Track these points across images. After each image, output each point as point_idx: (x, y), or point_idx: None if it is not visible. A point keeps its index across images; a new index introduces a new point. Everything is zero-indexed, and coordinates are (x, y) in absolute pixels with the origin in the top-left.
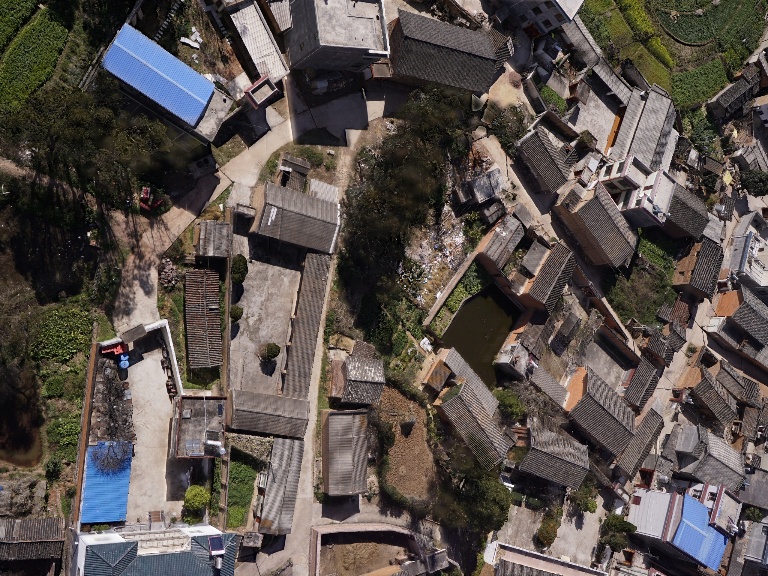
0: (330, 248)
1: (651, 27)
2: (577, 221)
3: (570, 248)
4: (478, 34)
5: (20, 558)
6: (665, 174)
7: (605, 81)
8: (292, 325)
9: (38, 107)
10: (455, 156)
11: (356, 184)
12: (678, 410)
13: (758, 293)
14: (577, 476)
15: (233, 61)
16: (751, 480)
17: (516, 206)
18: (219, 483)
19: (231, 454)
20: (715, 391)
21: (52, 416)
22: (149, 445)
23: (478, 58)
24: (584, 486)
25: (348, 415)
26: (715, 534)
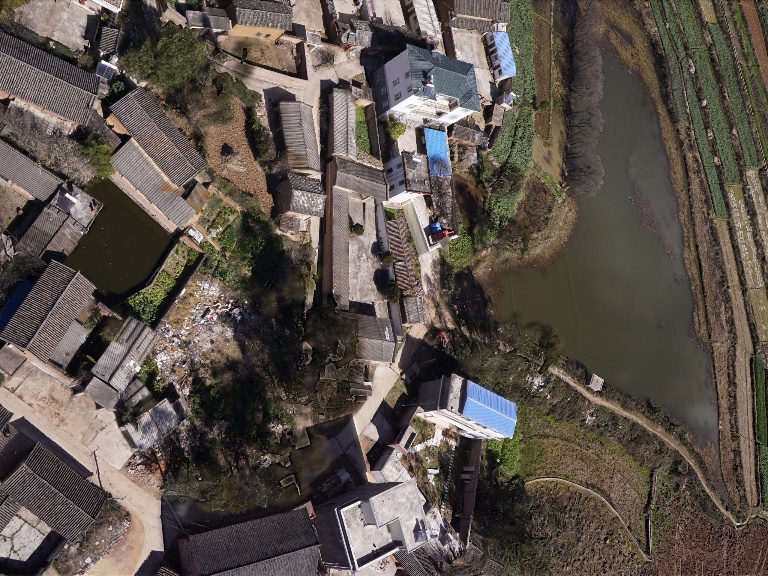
0: None
1: None
2: None
3: None
4: None
5: (465, 121)
6: None
7: None
8: None
9: None
10: None
11: None
12: None
13: None
14: (1, 43)
15: None
16: None
17: None
18: None
19: None
20: None
21: None
22: None
23: (225, 569)
24: None
25: (311, 168)
26: None
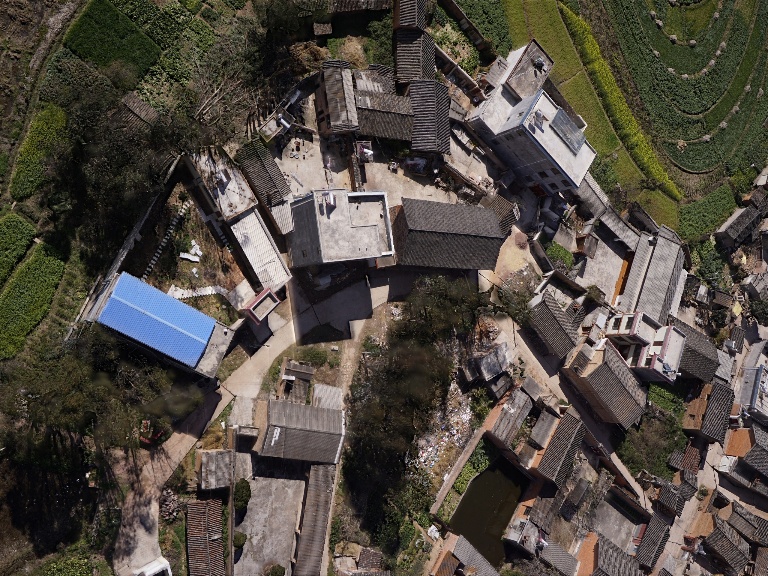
0: (335, 458)
1: (658, 161)
2: (586, 384)
3: (579, 407)
4: (484, 210)
5: None
6: (675, 329)
7: (612, 229)
8: (297, 539)
9: (34, 348)
10: (461, 330)
11: (361, 378)
12: (690, 561)
13: None
14: None
15: (234, 269)
16: None
17: (524, 380)
18: None
19: None
20: (728, 539)
21: None
22: None
23: (484, 238)
24: None
25: None
26: None
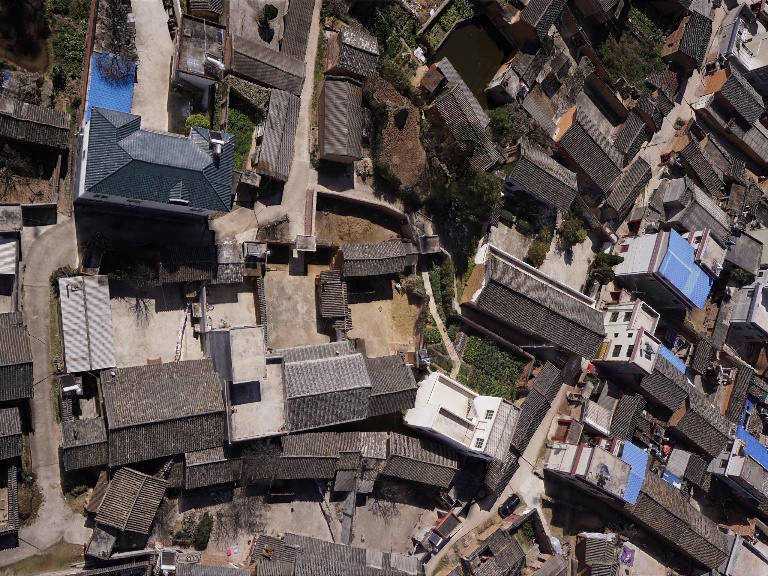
0: None
1: None
2: None
3: None
4: None
5: (28, 139)
6: None
7: None
8: None
9: None
10: None
11: None
12: (666, 171)
13: None
14: (566, 197)
15: None
16: (737, 242)
17: None
18: (218, 126)
19: (230, 101)
20: (702, 156)
21: (58, 30)
22: (151, 76)
23: None
24: (573, 220)
25: (343, 81)
26: (700, 273)
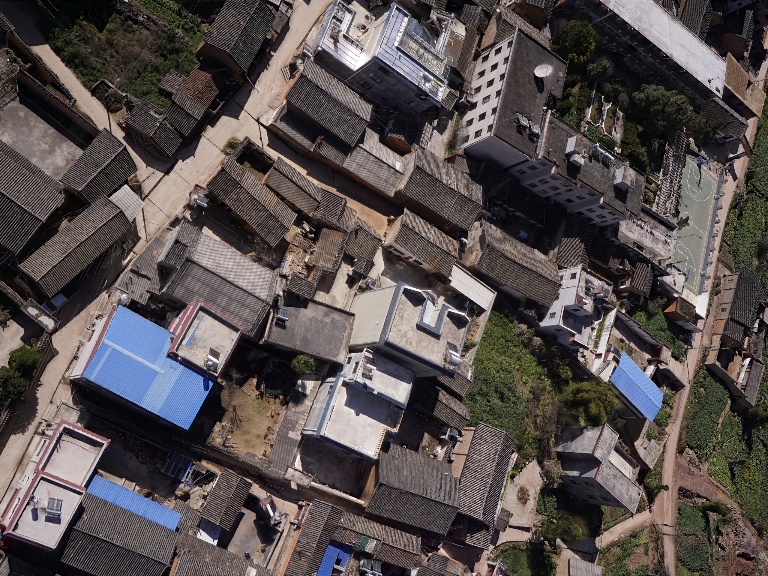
0: None
1: None
2: None
3: None
4: None
5: None
6: None
7: None
8: None
9: None
10: None
11: None
12: (184, 215)
13: (362, 88)
14: None
15: None
16: (300, 316)
17: None
18: None
19: None
20: (246, 191)
21: None
22: None
23: None
24: None
25: None
26: (182, 372)
